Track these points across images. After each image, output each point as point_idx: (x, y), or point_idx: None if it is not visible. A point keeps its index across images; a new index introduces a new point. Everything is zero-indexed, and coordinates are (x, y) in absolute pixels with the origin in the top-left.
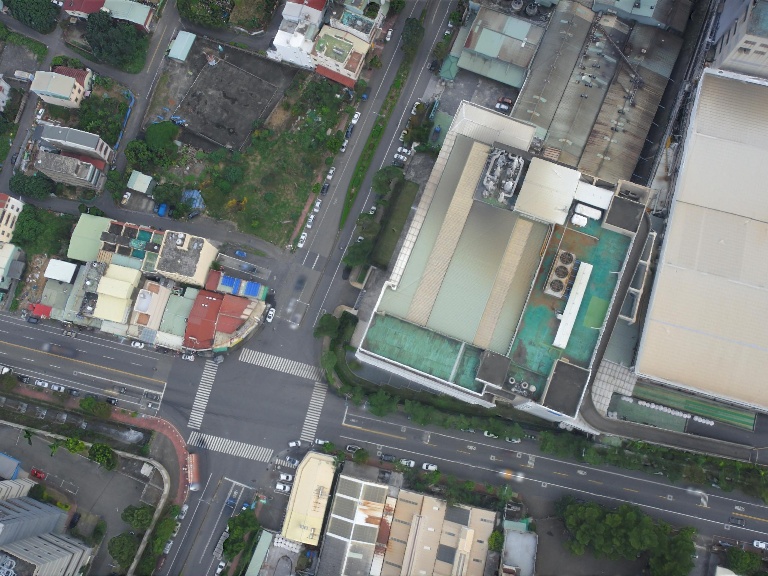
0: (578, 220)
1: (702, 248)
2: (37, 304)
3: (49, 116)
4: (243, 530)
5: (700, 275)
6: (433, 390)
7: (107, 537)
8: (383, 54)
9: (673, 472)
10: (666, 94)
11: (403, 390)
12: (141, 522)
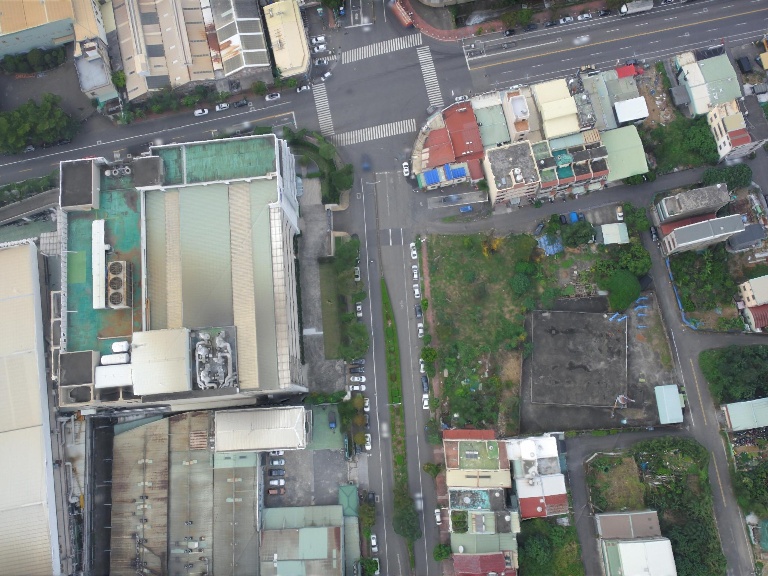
0: (120, 344)
1: (5, 383)
2: None
3: (767, 263)
4: None
5: None
6: None
7: None
8: (434, 491)
9: None
10: (107, 568)
11: None
12: None
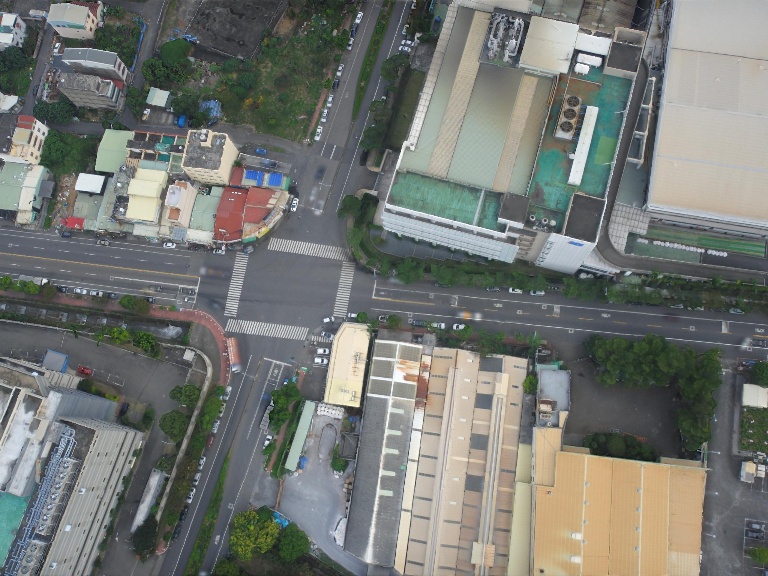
0: (581, 68)
1: (700, 87)
2: (69, 218)
3: None
4: (287, 400)
5: (700, 110)
6: (456, 257)
7: (156, 422)
8: None
9: (693, 300)
10: None
11: (428, 260)
12: (189, 398)
